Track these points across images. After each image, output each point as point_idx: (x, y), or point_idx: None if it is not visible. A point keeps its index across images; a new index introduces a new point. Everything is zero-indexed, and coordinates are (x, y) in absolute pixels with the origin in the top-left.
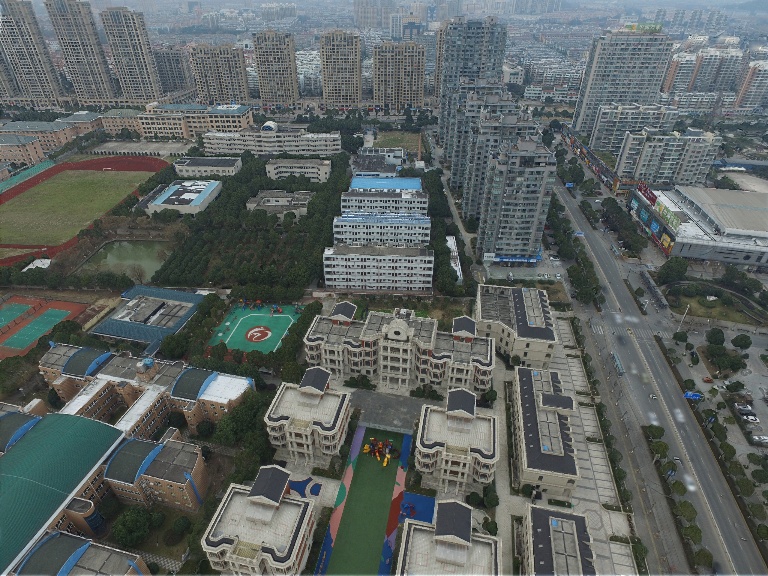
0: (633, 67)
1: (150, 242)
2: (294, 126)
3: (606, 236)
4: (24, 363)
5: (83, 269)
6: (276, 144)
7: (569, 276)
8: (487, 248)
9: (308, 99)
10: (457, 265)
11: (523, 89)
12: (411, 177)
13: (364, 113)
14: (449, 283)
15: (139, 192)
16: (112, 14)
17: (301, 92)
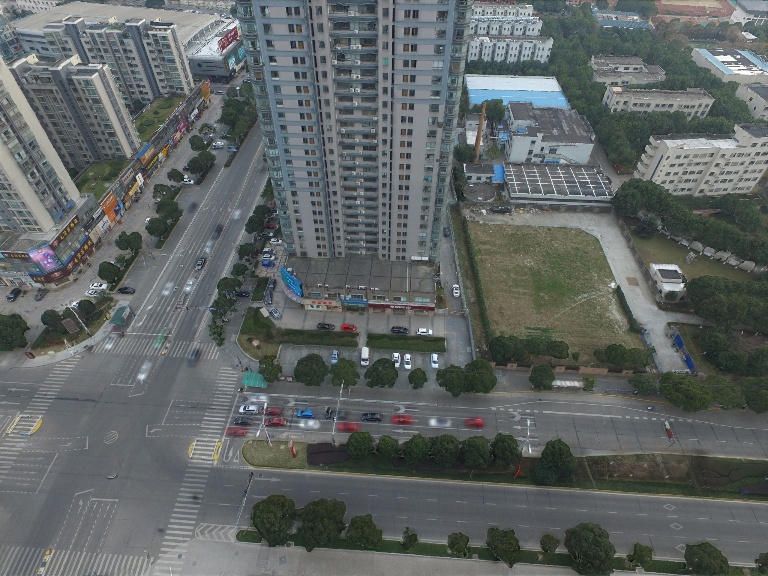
0: None
1: None
2: None
3: None
4: None
5: (701, 26)
6: None
7: None
8: None
9: None
10: None
11: None
12: None
13: None
14: None
15: None
16: None
17: None
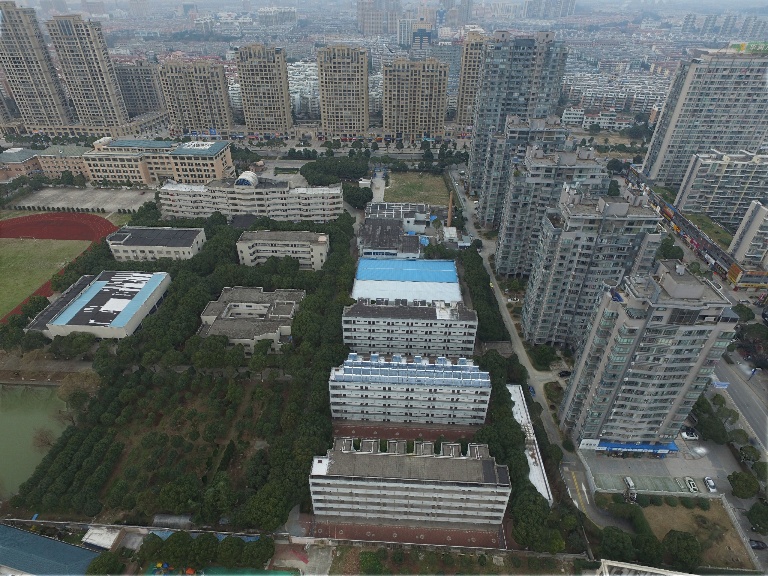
0: (736, 100)
1: (46, 387)
2: (285, 164)
3: (752, 378)
4: None
5: None
6: (256, 202)
7: (736, 495)
8: (587, 432)
9: (303, 126)
10: (537, 461)
11: (559, 111)
12: (441, 259)
13: (372, 146)
14: (540, 539)
15: (52, 287)
16: (60, 24)
17: (296, 114)
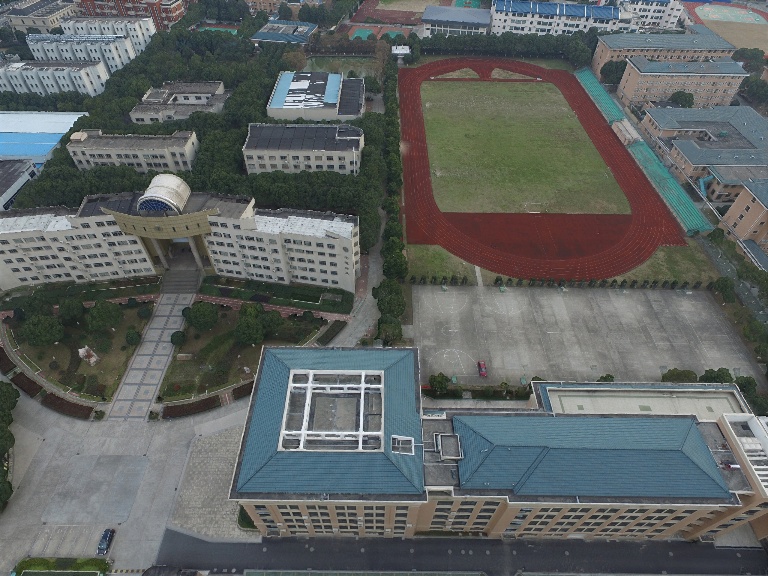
0: None
1: None
2: None
3: None
4: (334, 7)
5: (354, 40)
6: None
7: None
8: None
9: None
10: None
11: None
12: None
13: None
14: None
15: None
16: None
17: None
